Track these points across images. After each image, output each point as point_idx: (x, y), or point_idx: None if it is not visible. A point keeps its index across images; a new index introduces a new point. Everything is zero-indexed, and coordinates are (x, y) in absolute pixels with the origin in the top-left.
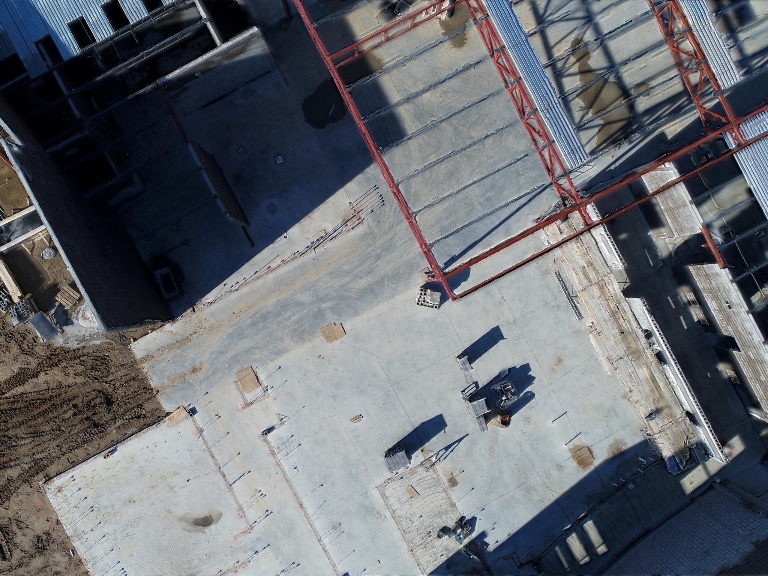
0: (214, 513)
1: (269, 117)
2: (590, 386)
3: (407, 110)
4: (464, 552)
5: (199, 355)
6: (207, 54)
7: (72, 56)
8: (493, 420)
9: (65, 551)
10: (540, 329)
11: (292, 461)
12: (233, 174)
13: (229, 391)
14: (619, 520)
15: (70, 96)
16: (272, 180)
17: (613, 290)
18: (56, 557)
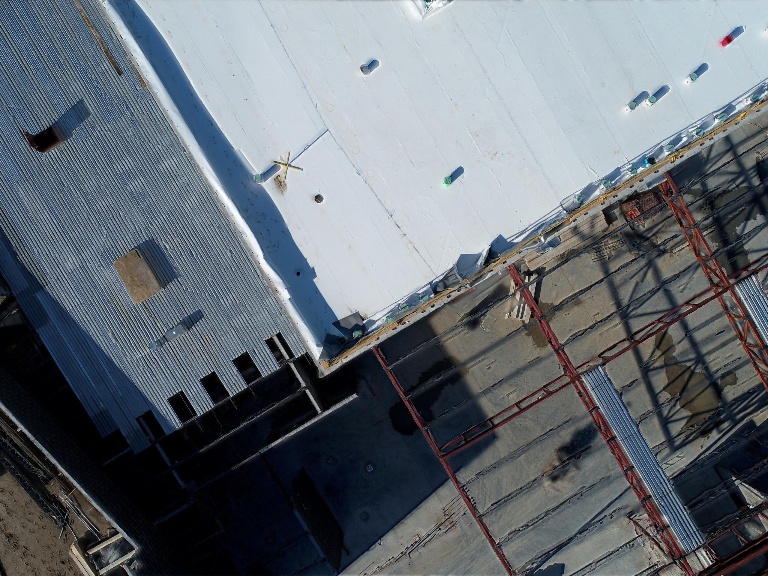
0: None
1: (357, 427)
2: None
3: (494, 412)
4: None
5: None
6: (308, 423)
7: (174, 430)
8: None
9: None
10: None
11: None
12: (324, 485)
13: None
14: None
15: (174, 468)
16: (363, 489)
17: None
18: None
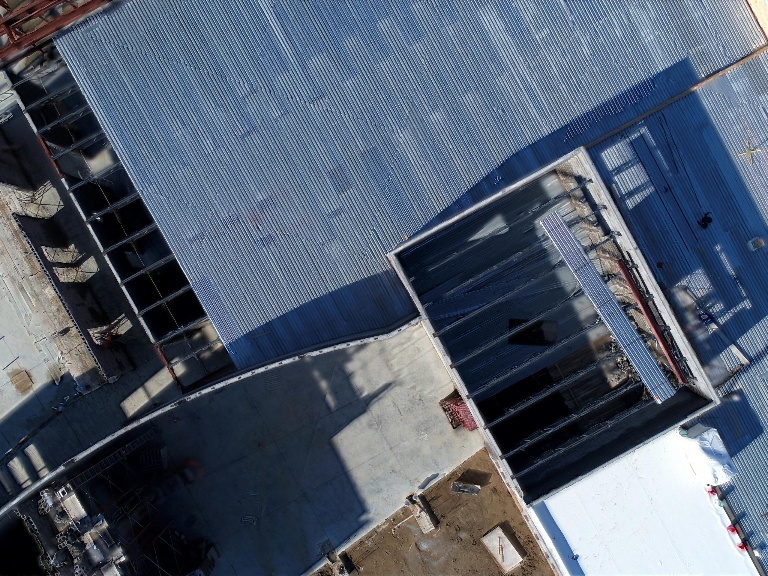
0: None
1: None
2: None
3: None
4: None
5: None
6: None
7: None
8: None
9: None
10: None
11: None
12: None
13: None
14: (60, 444)
15: None
16: None
17: (15, 209)
18: None
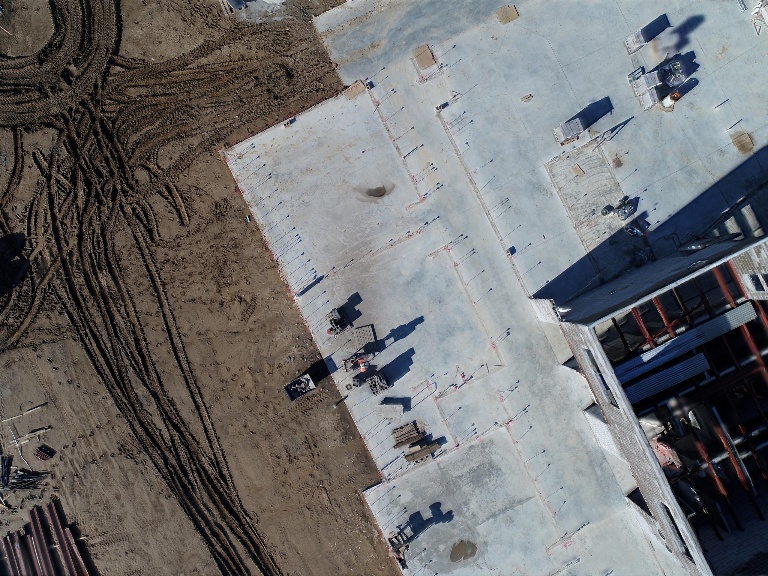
0: (387, 184)
1: None
2: (752, 75)
3: None
4: (626, 230)
5: (377, 32)
6: None
7: None
8: (658, 104)
9: (242, 217)
10: (705, 18)
11: (463, 137)
12: None
13: (405, 67)
14: None
15: None
16: None
17: None
18: (233, 223)
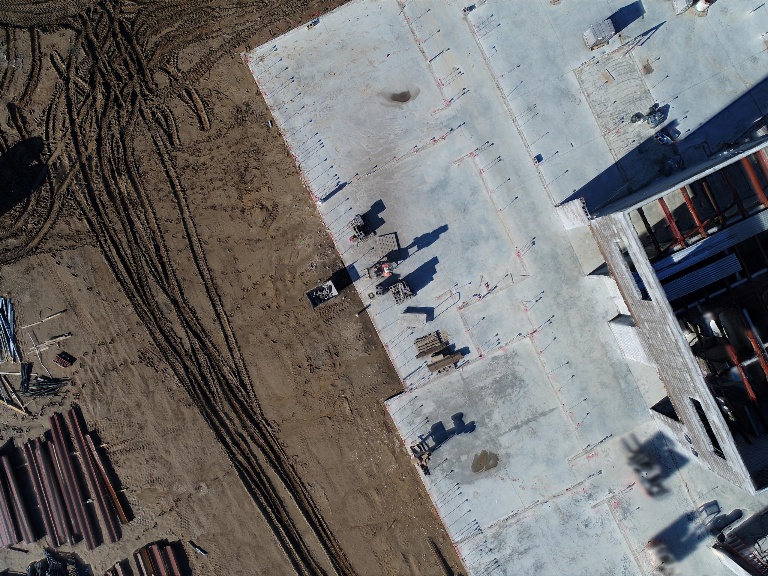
0: (412, 89)
1: None
2: None
3: None
4: (656, 138)
5: None
6: None
7: None
8: (691, 8)
9: (264, 122)
10: None
11: (491, 41)
12: None
13: None
14: None
15: None
16: None
17: None
18: (254, 128)
